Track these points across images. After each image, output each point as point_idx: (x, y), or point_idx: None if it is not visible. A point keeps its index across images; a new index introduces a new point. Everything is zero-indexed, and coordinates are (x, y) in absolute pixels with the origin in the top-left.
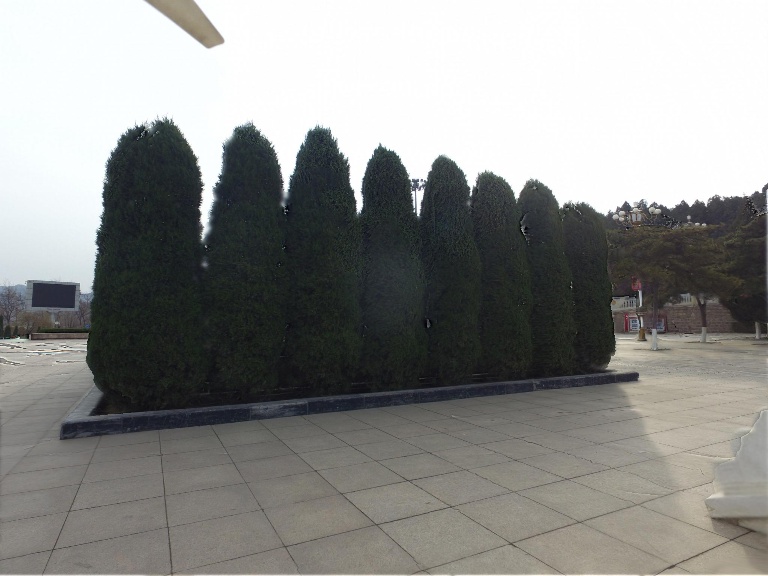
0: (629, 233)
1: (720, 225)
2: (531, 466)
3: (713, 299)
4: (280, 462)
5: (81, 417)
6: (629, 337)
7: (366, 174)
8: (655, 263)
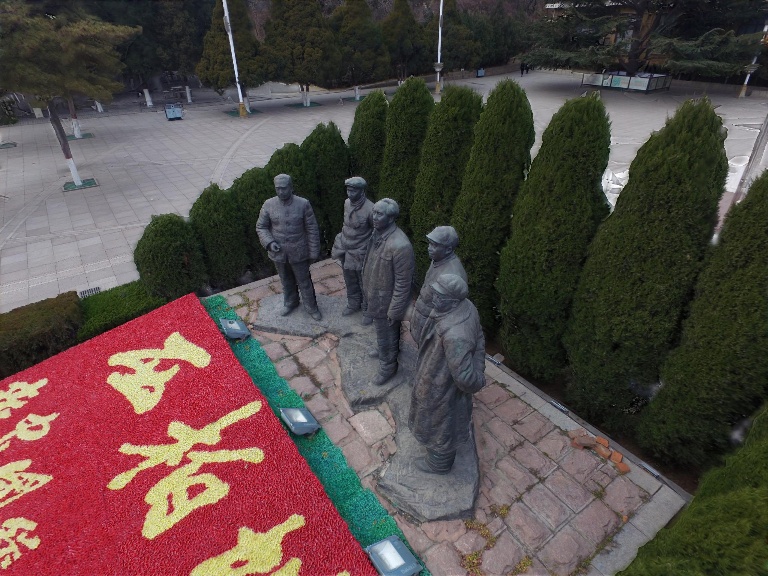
0: None
1: (139, 29)
2: None
3: (6, 91)
4: None
5: None
6: None
7: None
8: (76, 75)
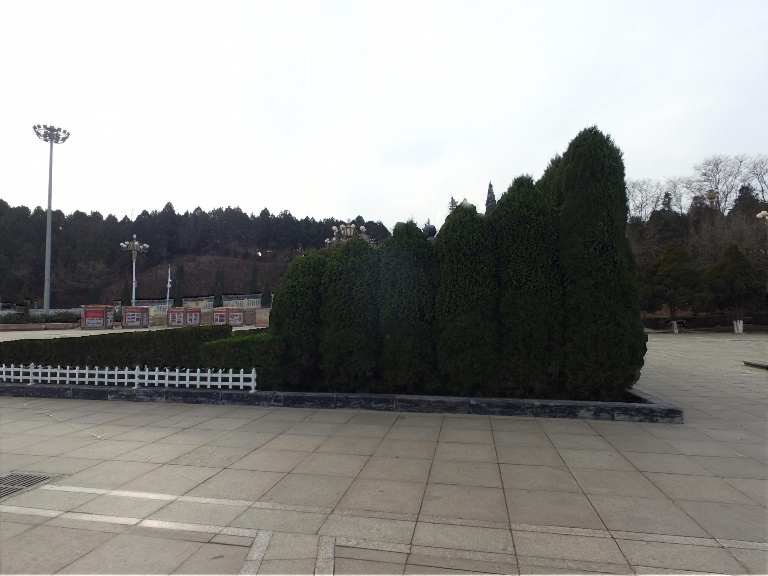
0: None
1: None
2: (767, 384)
3: None
4: (764, 400)
5: (659, 404)
6: None
7: None
8: None
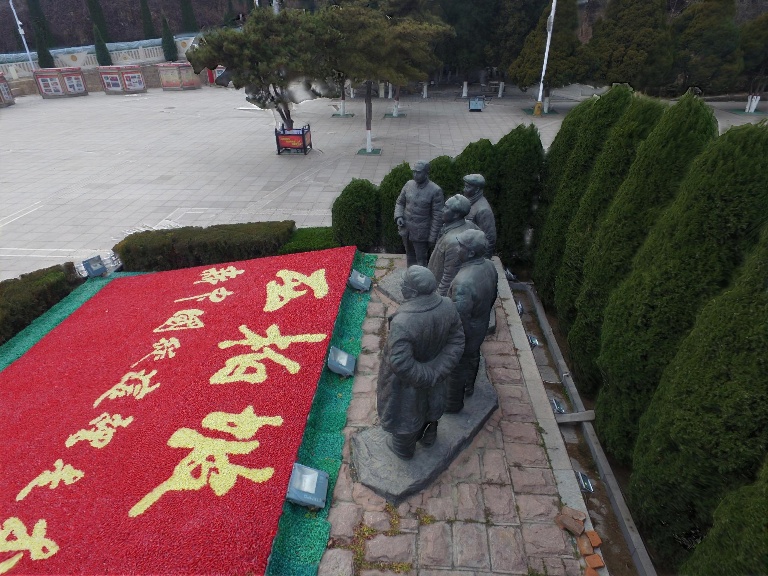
0: (343, 14)
1: (447, 28)
2: None
3: None
4: None
5: None
6: (247, 102)
7: (766, 194)
8: (388, 64)
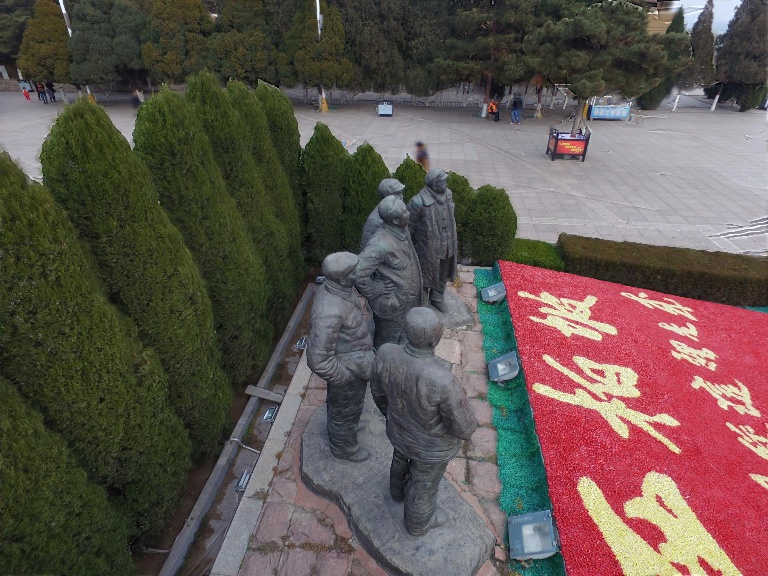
0: None
1: None
2: None
3: None
4: None
5: None
6: None
7: None
8: None
